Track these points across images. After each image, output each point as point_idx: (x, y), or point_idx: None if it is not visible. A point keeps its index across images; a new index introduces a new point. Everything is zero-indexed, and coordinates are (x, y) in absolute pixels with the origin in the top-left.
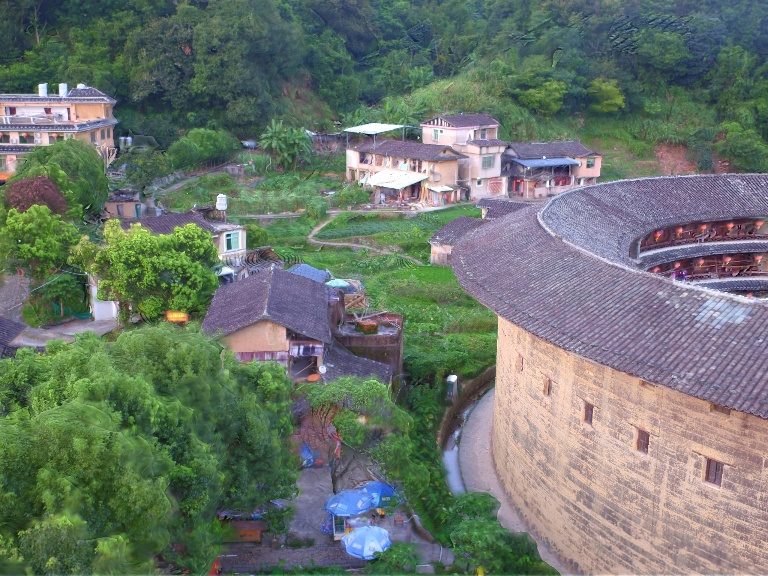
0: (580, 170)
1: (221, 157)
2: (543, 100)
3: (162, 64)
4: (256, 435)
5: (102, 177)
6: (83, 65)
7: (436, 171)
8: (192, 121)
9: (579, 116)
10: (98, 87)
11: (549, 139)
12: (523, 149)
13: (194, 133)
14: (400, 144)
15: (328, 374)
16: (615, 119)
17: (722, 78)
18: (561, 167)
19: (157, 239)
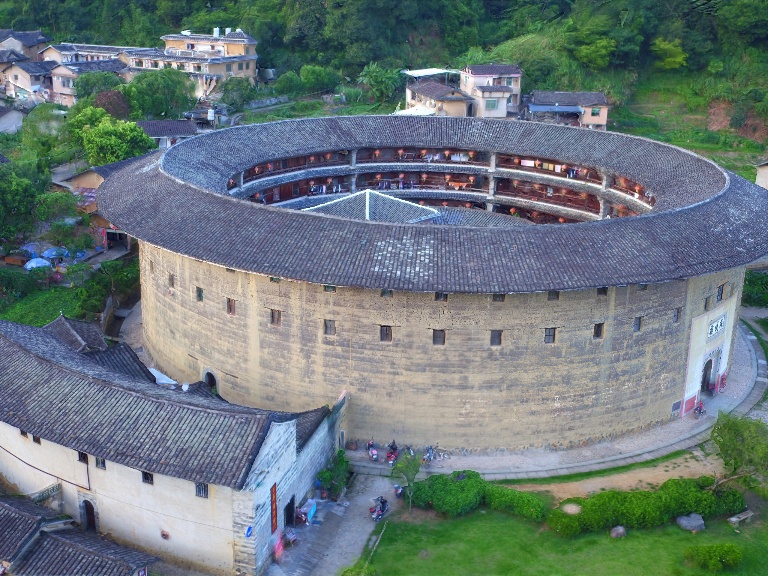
0: (585, 117)
1: (325, 88)
2: (590, 55)
3: (308, 15)
4: None
5: (177, 95)
6: (258, 14)
7: (444, 108)
8: (320, 60)
9: (634, 71)
10: (257, 31)
11: (592, 90)
12: (542, 96)
13: (304, 69)
14: (433, 86)
15: None
16: (681, 76)
17: None
18: (573, 114)
19: (104, 128)
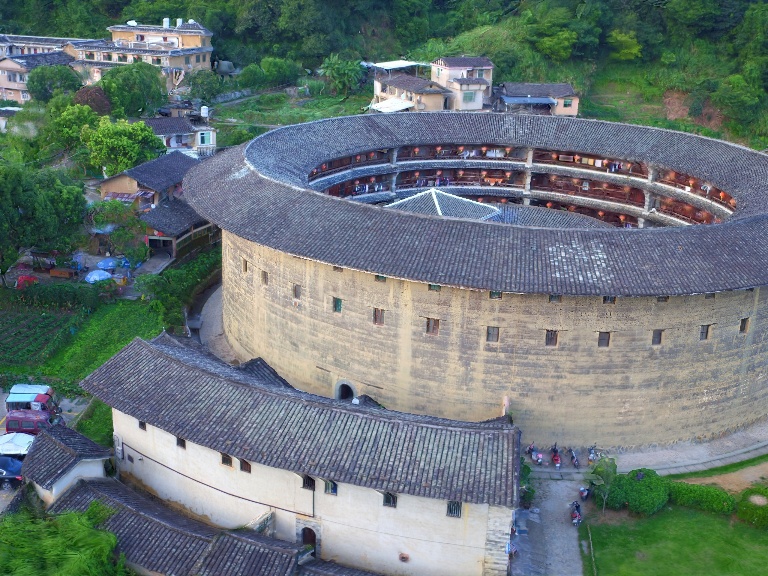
0: (557, 108)
1: (286, 81)
2: (553, 47)
3: (260, 5)
4: (37, 213)
5: (154, 90)
6: (205, 4)
7: (422, 101)
8: (276, 51)
9: (593, 62)
10: (208, 22)
11: (556, 81)
12: (514, 88)
13: (265, 61)
14: (406, 78)
15: (156, 209)
16: (635, 66)
17: (746, 33)
18: (545, 105)
19: (113, 128)
